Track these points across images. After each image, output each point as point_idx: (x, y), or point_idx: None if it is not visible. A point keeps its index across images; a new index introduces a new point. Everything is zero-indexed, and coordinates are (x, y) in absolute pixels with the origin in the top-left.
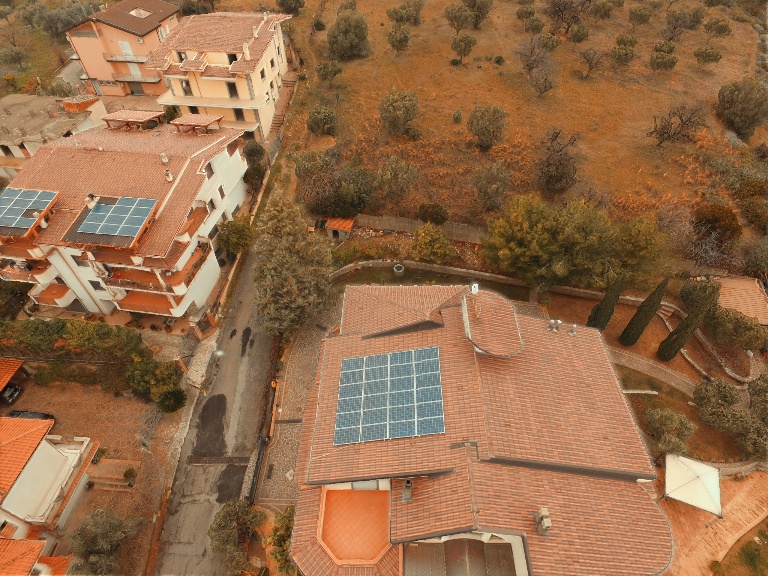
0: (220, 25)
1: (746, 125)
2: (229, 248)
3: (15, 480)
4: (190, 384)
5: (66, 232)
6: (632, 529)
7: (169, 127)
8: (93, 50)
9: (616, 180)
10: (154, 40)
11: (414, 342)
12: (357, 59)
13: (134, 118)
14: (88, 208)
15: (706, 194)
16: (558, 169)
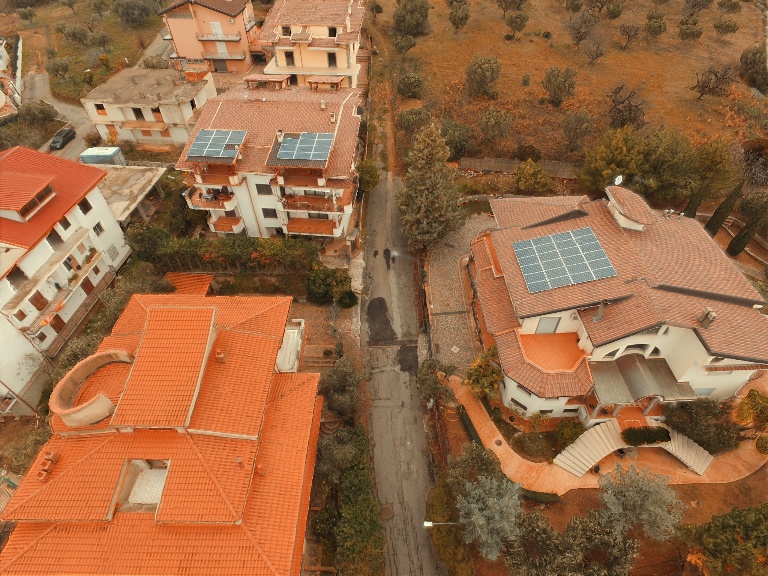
0: (315, 4)
1: (766, 82)
2: (360, 186)
3: (283, 333)
4: (352, 291)
5: (267, 159)
6: (759, 331)
7: (297, 87)
8: (186, 30)
9: (670, 126)
10: (240, 21)
11: (568, 227)
12: (421, 36)
13: (272, 78)
14: (278, 141)
15: (746, 133)
16: (631, 113)
